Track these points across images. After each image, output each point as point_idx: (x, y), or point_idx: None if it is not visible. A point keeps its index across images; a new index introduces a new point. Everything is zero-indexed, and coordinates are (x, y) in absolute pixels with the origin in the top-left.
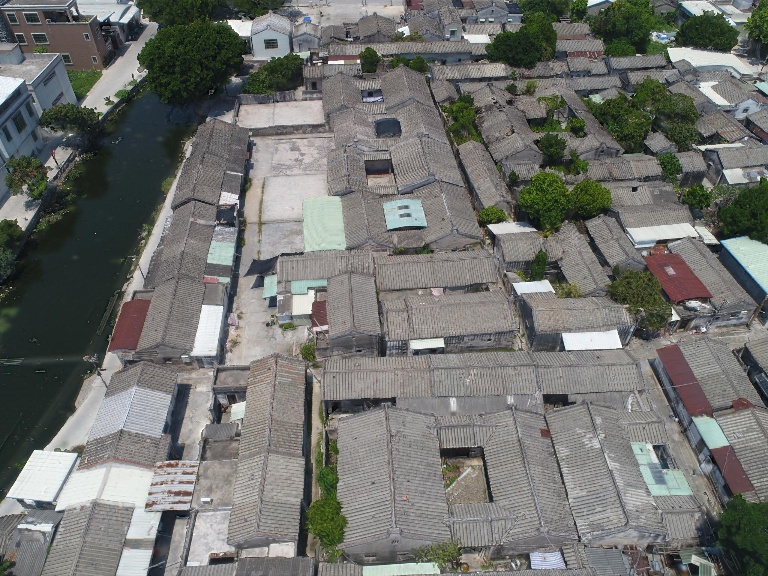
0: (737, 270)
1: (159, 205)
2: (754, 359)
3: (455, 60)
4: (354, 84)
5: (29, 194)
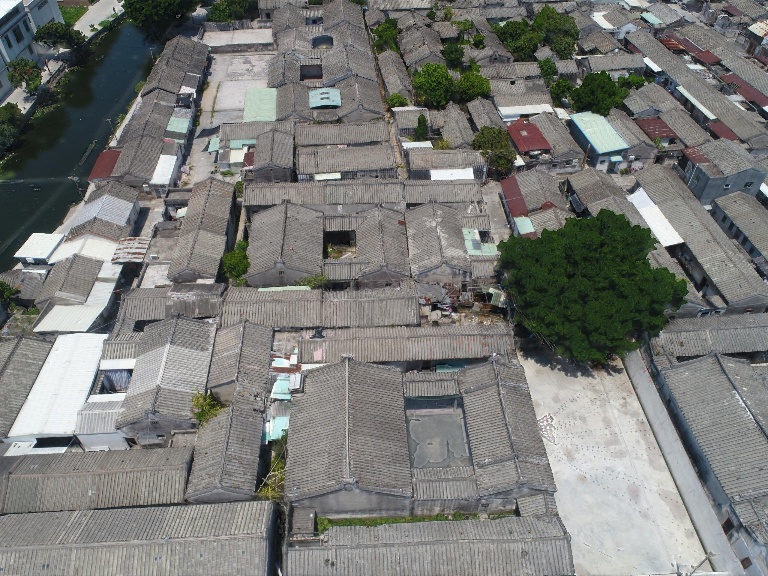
0: (579, 135)
1: None
2: (571, 186)
3: None
4: (300, 13)
5: (27, 88)
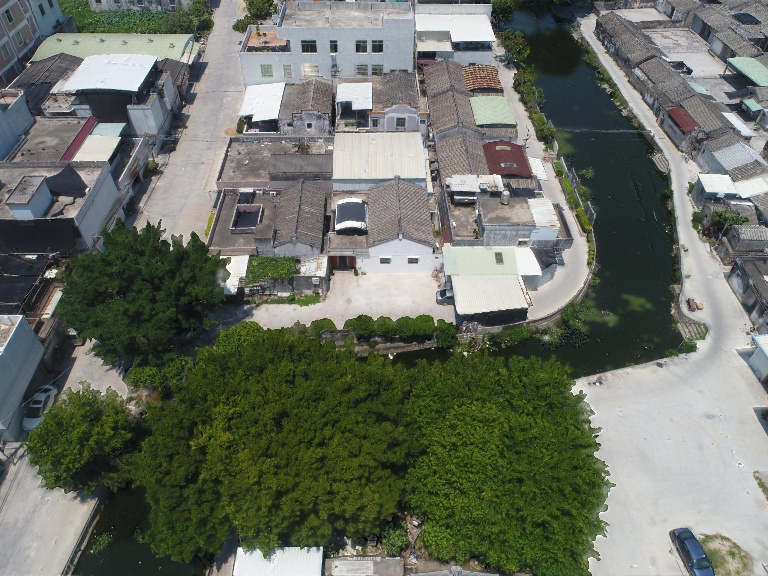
0: None
1: (595, 70)
2: None
3: None
4: None
5: (520, 56)
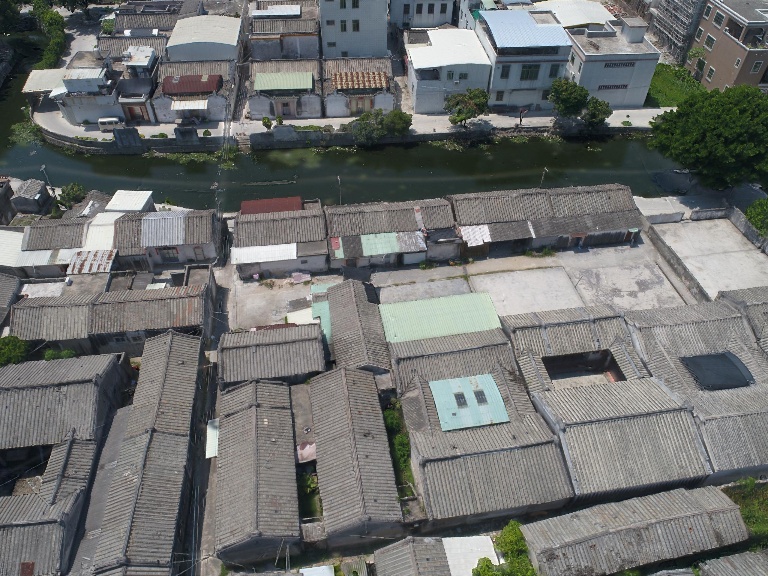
0: None
1: None
2: None
3: None
4: None
5: (450, 116)
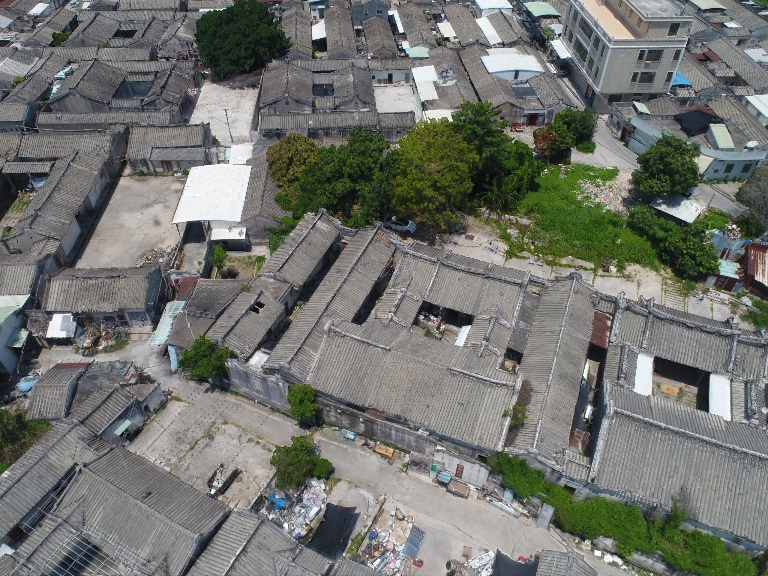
0: None
1: None
2: None
3: None
4: None
5: None
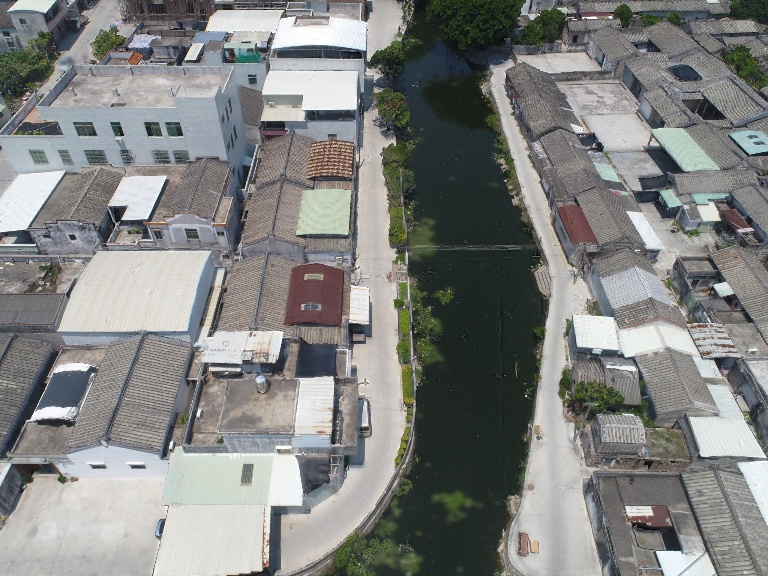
0: None
1: (495, 138)
2: None
3: (692, 19)
4: (624, 36)
5: (397, 123)
